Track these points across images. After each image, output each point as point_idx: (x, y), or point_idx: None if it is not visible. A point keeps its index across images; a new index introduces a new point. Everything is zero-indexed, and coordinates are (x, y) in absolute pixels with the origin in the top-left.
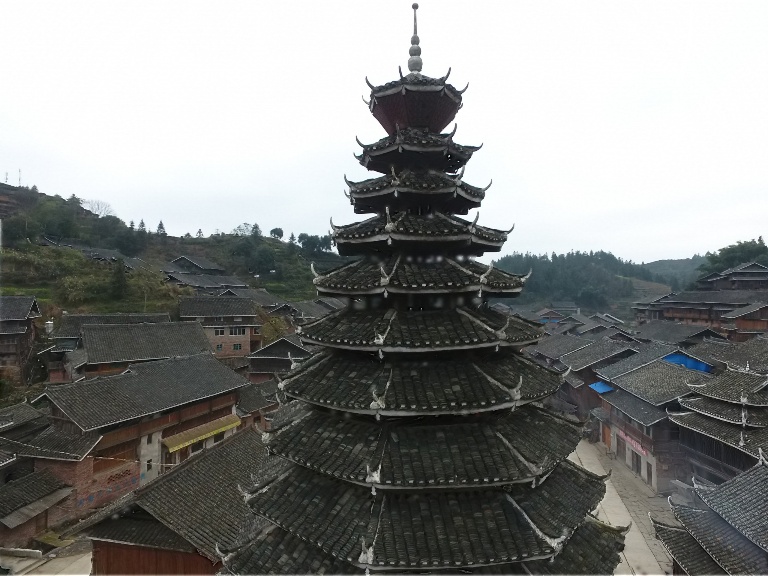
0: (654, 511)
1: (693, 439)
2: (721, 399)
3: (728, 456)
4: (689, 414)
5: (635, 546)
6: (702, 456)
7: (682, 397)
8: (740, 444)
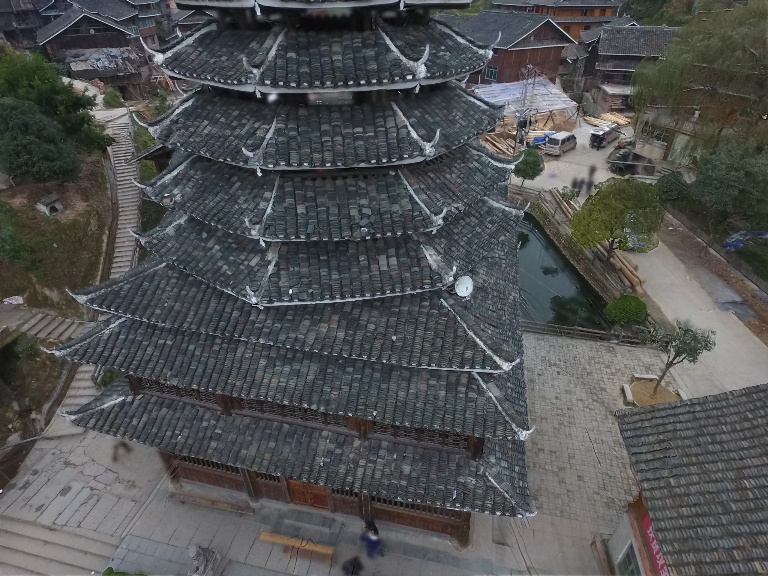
0: None
1: None
2: None
3: None
4: None
5: None
6: None
7: None
8: None
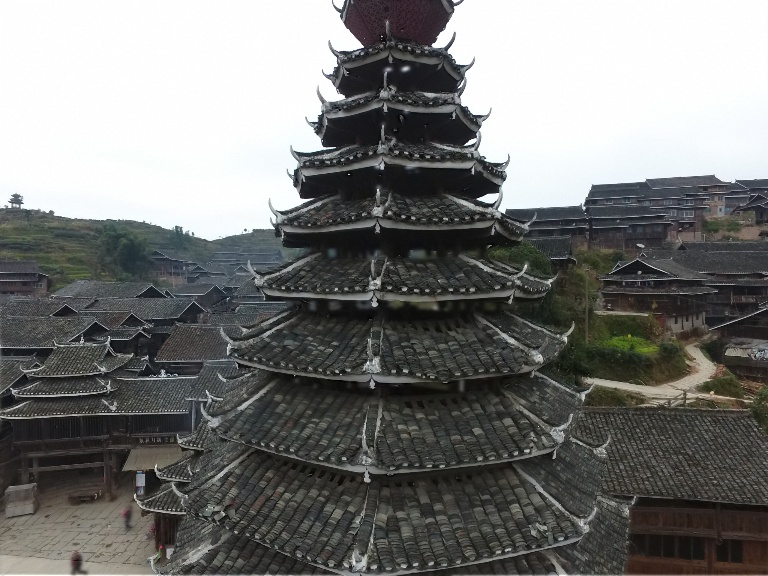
0: (3, 534)
1: (38, 429)
2: (74, 375)
3: (90, 428)
4: (27, 404)
5: (49, 569)
6: (53, 442)
7: (8, 389)
8: (113, 409)
